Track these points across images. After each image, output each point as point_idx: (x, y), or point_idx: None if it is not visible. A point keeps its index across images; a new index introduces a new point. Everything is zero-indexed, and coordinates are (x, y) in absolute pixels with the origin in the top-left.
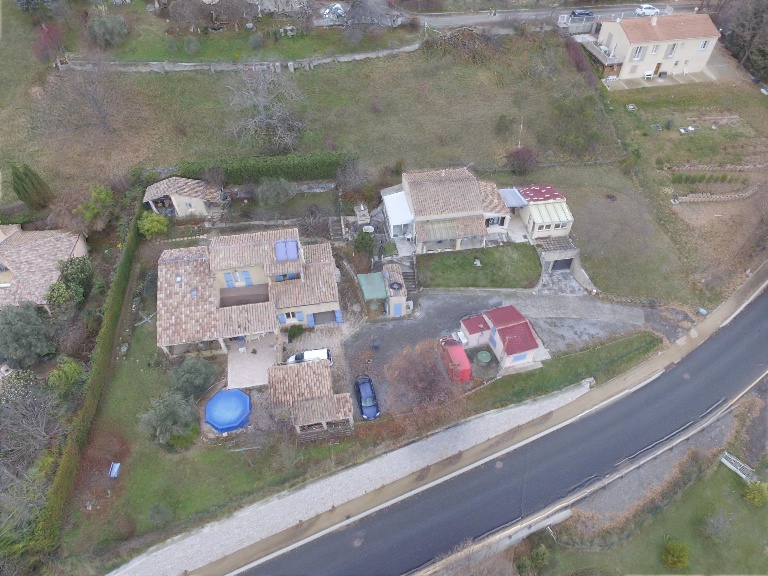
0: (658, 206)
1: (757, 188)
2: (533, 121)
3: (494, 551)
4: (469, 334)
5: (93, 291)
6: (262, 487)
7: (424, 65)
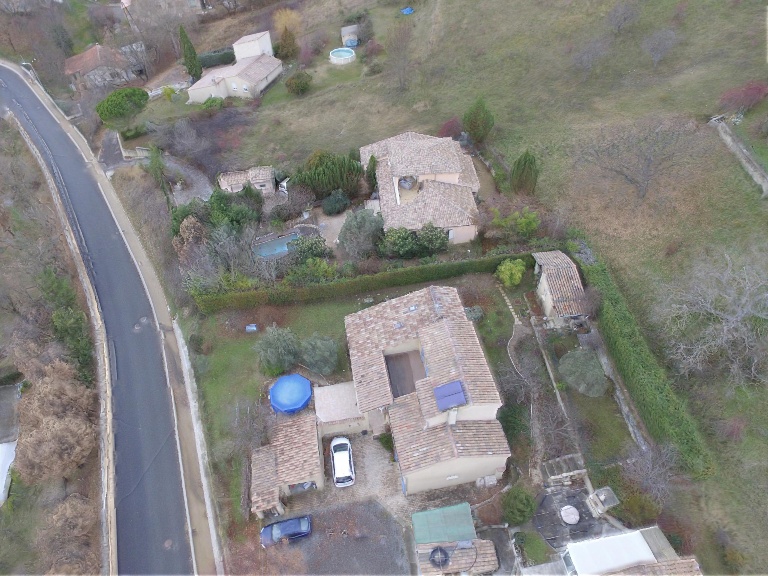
0: None
1: None
2: None
3: None
4: None
5: None
6: (213, 437)
7: None
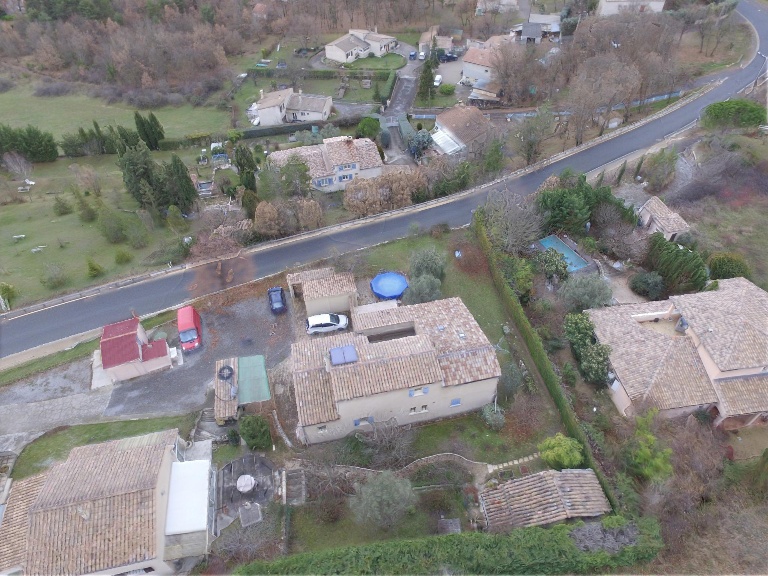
0: None
1: None
2: None
3: None
4: None
5: None
6: None
7: None
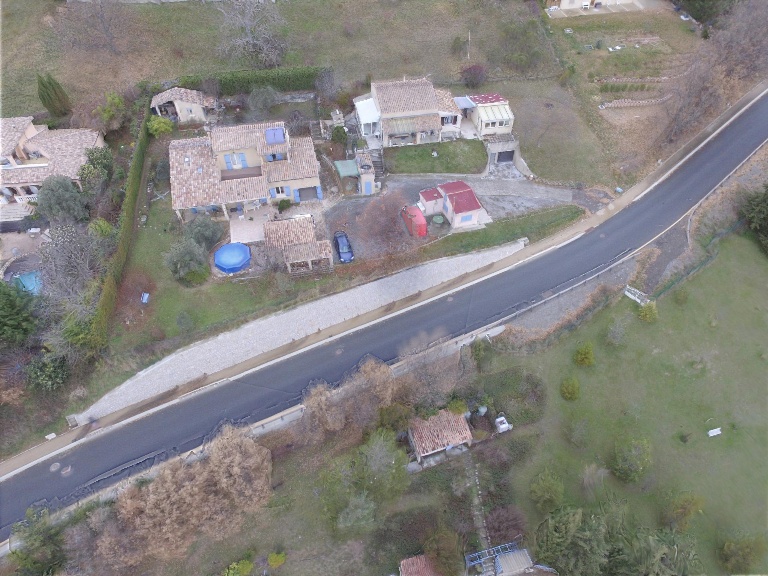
0: (588, 111)
1: (670, 95)
2: (484, 43)
3: (444, 353)
4: (426, 201)
5: (113, 178)
6: (262, 307)
7: None
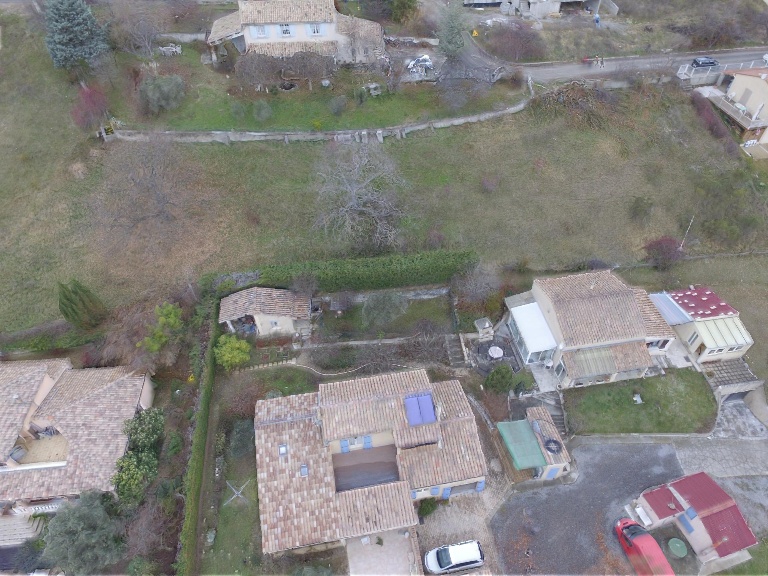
0: None
1: None
2: (673, 202)
3: None
4: (658, 518)
5: (164, 449)
6: None
7: (534, 131)
